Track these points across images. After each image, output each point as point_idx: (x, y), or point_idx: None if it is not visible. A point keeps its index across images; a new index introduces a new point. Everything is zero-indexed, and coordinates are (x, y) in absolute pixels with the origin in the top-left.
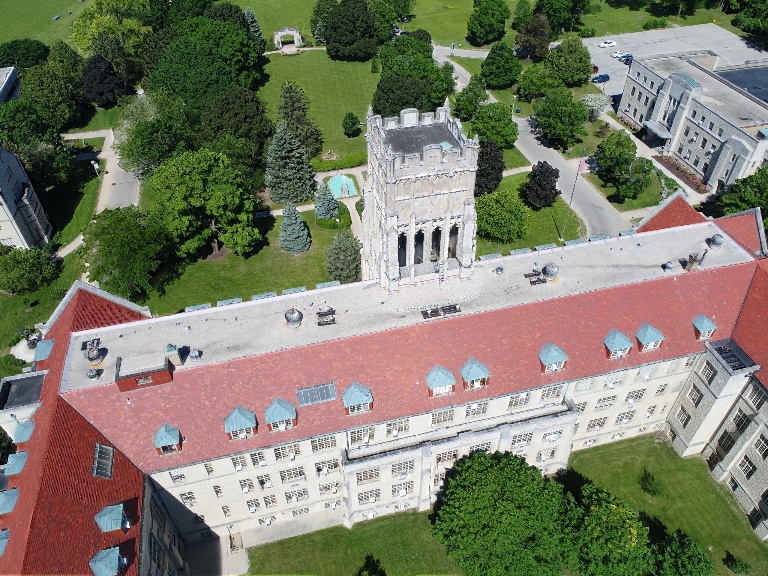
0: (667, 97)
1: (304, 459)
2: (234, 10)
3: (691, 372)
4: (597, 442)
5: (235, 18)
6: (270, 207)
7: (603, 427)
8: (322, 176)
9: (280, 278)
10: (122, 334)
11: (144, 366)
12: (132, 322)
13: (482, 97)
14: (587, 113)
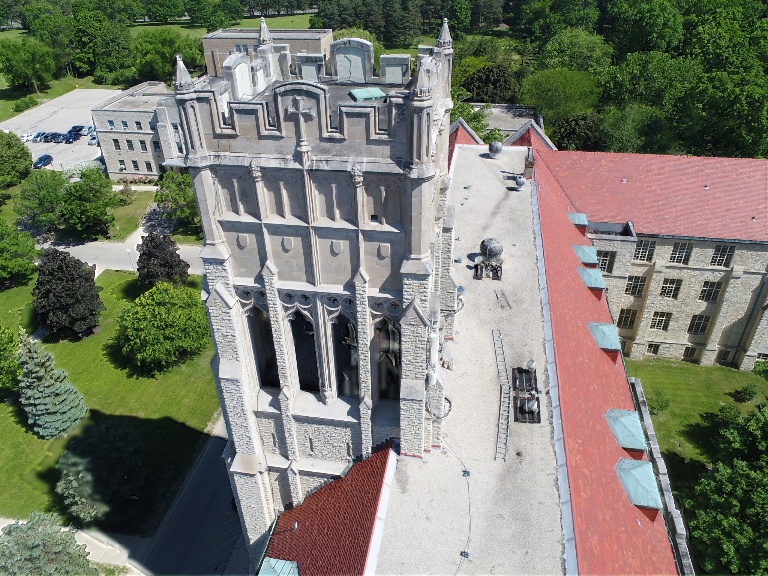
0: (170, 127)
1: None
2: None
3: None
4: None
5: None
6: None
7: None
8: None
9: None
10: None
11: None
12: None
13: None
14: (104, 178)
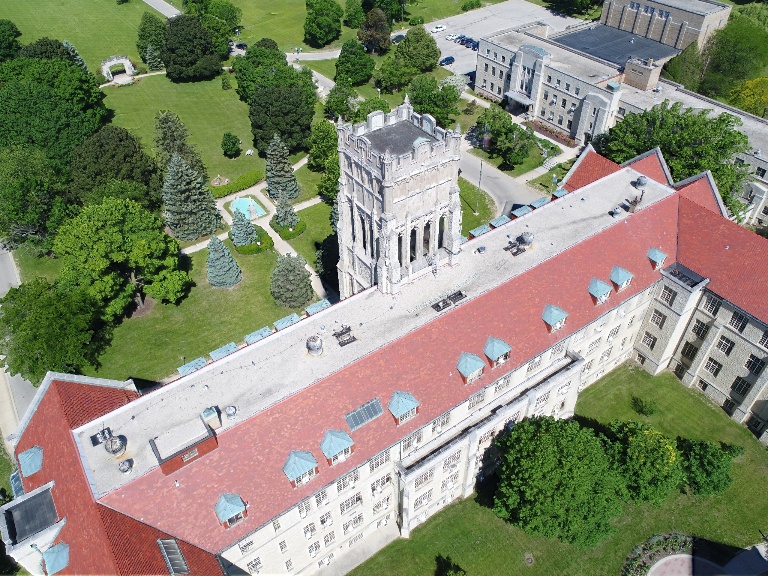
0: (521, 68)
1: (362, 484)
2: (55, 45)
3: (652, 299)
4: (586, 384)
5: (59, 54)
6: (179, 246)
7: (590, 369)
8: (221, 203)
9: (224, 316)
10: (133, 415)
11: (185, 440)
12: (139, 399)
13: (352, 95)
14: None
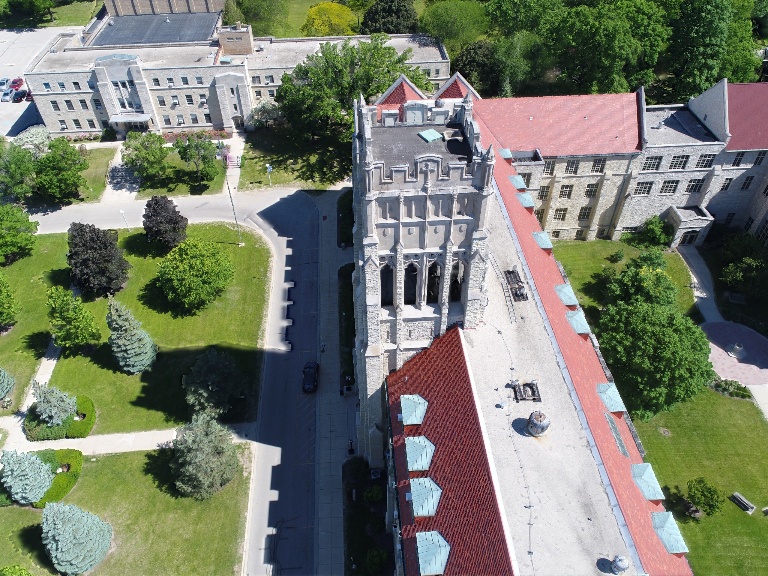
0: (111, 85)
1: None
2: None
3: None
4: None
5: None
6: None
7: None
8: None
9: None
10: None
11: None
12: None
13: None
14: None
